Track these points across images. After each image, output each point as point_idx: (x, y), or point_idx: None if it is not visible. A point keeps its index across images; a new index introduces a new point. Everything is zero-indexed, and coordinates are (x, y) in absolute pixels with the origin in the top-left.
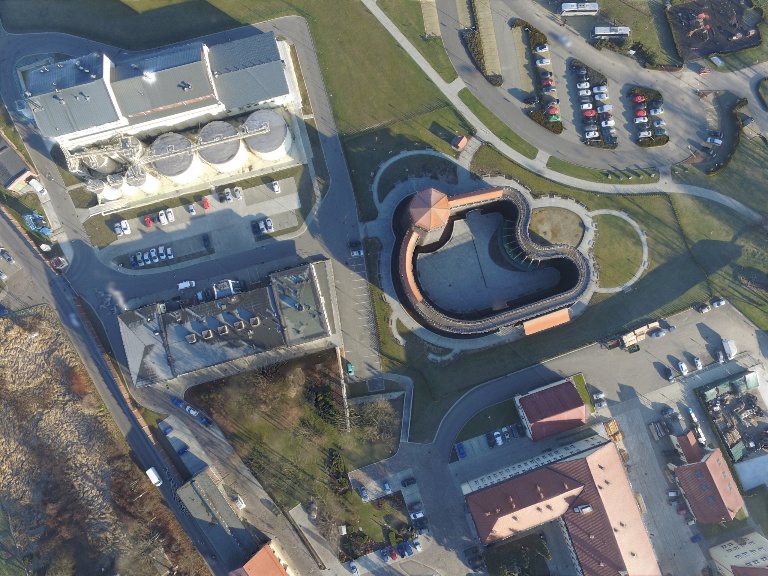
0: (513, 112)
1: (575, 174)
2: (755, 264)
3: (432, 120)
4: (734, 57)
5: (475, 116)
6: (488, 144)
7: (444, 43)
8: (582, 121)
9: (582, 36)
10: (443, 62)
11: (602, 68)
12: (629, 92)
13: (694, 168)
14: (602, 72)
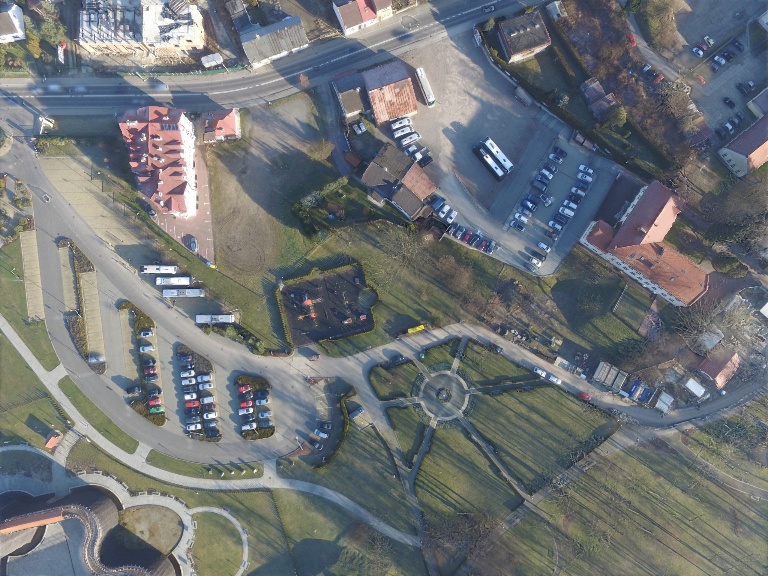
0: (115, 401)
1: (175, 469)
2: (349, 572)
3: (29, 412)
4: (347, 341)
5: (74, 407)
6: (86, 438)
7: (48, 327)
8: (184, 412)
9: (191, 318)
10: (45, 348)
11: (210, 353)
12: (235, 381)
13: (301, 461)
14: (210, 358)
